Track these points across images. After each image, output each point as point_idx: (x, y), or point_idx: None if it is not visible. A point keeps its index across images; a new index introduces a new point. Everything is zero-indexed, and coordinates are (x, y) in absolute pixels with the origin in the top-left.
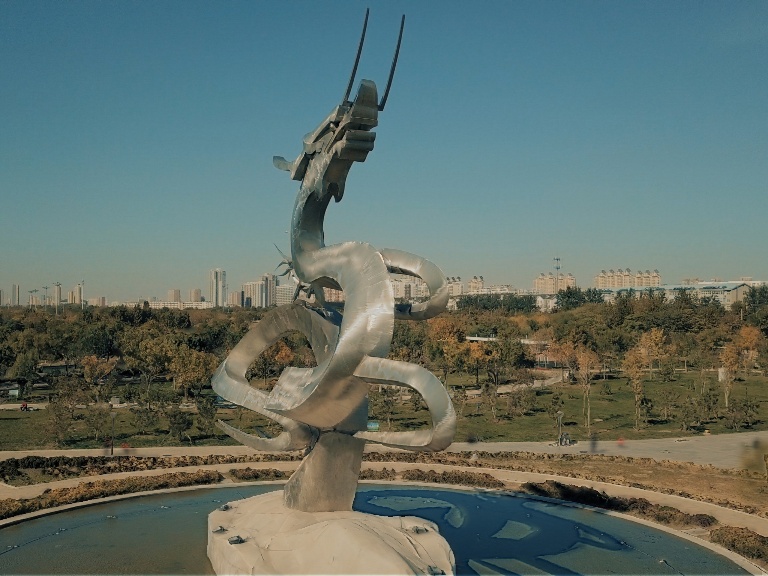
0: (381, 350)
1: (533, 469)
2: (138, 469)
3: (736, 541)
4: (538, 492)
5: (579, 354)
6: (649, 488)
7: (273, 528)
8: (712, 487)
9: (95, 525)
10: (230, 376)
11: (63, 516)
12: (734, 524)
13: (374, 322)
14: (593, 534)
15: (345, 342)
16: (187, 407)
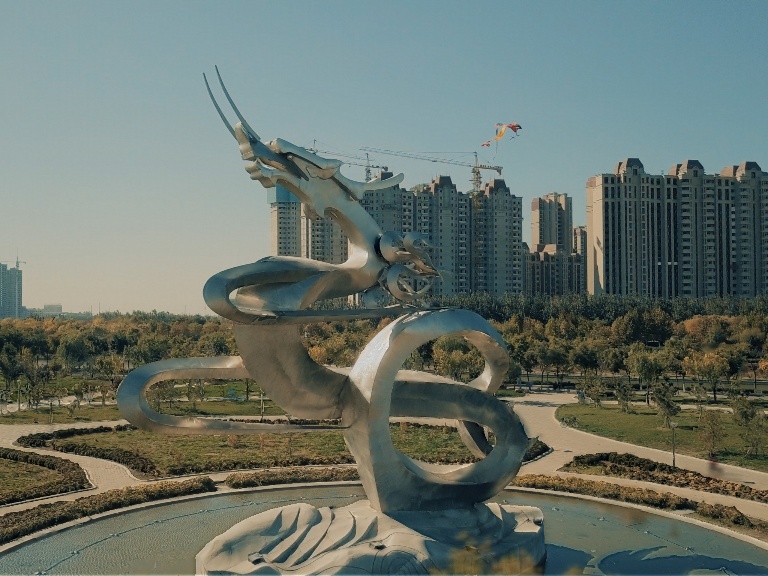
0: None
1: None
2: (666, 483)
3: None
4: None
5: None
6: None
7: None
8: None
9: None
10: None
11: None
12: None
13: None
14: None
15: None
16: None
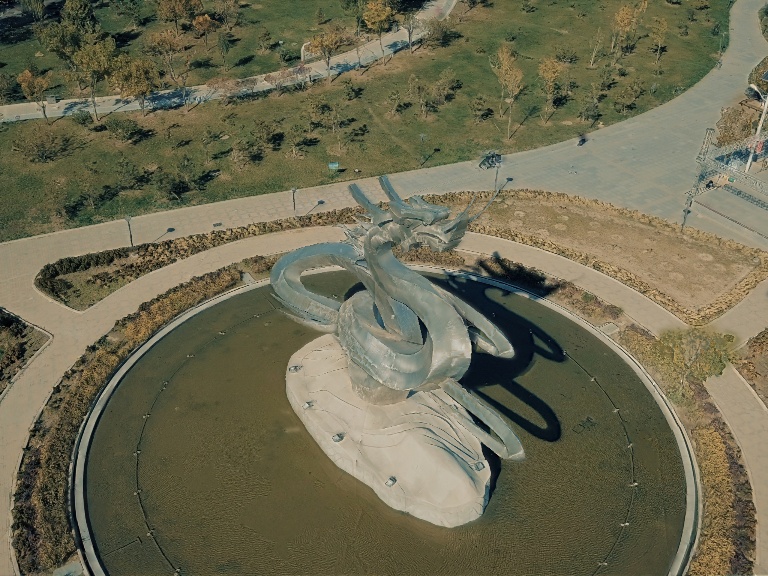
0: (459, 375)
1: (480, 229)
2: (163, 265)
3: (638, 350)
4: (493, 274)
5: (502, 55)
6: (571, 257)
7: (359, 423)
8: (614, 245)
9: (184, 370)
10: (291, 286)
11: (150, 358)
12: (633, 313)
13: (457, 362)
14: (543, 340)
15: (435, 371)
16: (130, 108)
